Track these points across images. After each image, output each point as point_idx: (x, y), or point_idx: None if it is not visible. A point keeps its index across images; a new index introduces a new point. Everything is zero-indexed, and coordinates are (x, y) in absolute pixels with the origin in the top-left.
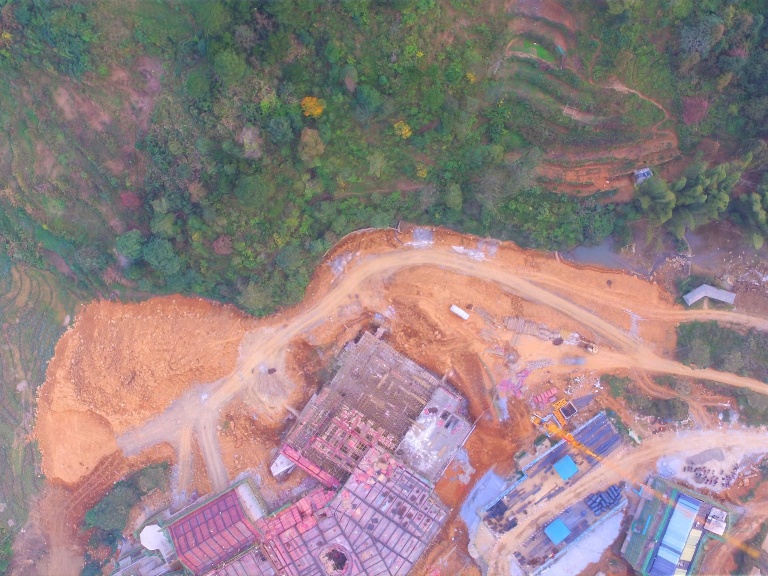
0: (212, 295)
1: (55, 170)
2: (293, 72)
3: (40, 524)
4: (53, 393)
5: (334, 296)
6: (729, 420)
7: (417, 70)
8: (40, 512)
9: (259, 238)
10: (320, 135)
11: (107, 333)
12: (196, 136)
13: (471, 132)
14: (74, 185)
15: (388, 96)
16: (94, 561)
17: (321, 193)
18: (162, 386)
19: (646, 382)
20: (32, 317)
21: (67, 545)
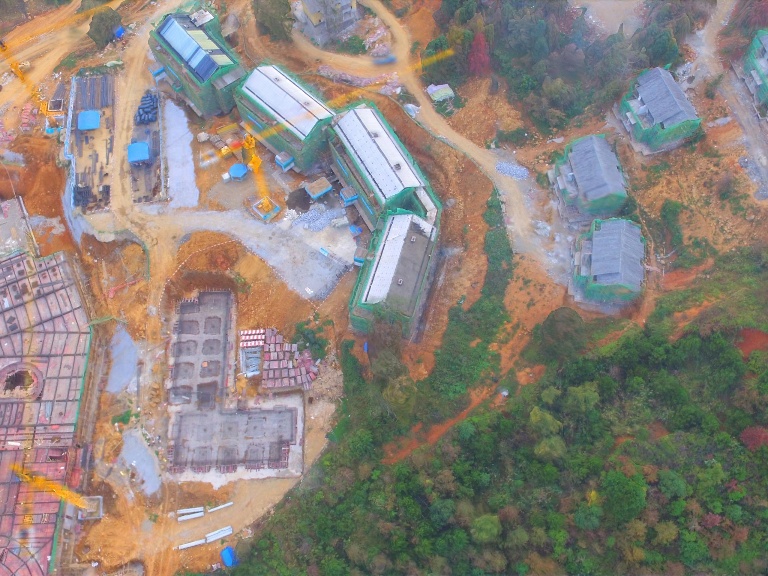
0: None
1: None
2: None
3: None
4: None
5: None
6: None
7: None
8: None
9: None
10: None
11: None
12: None
13: None
14: None
15: None
16: None
17: None
18: None
19: (86, 43)
20: None
21: None
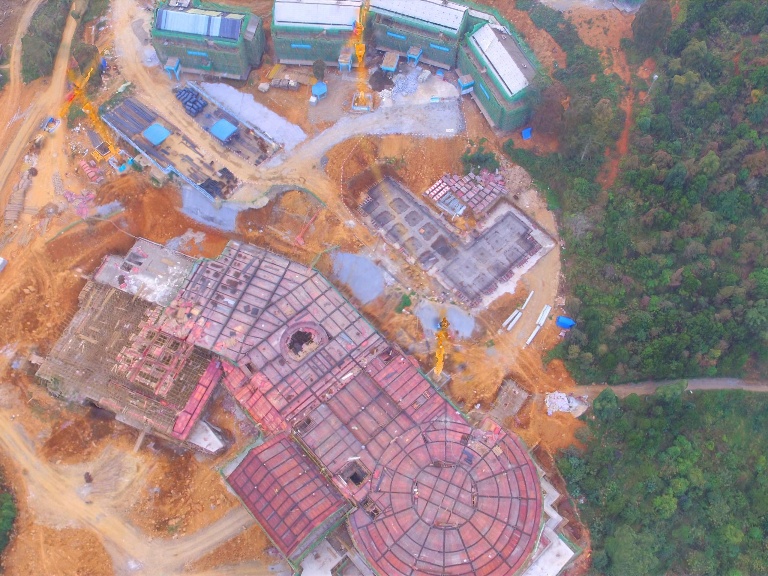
0: None
1: None
2: None
3: None
4: None
5: None
6: (104, 22)
7: None
8: None
9: None
10: None
11: None
12: None
13: None
14: None
15: None
16: None
17: None
18: None
19: None
20: None
21: None
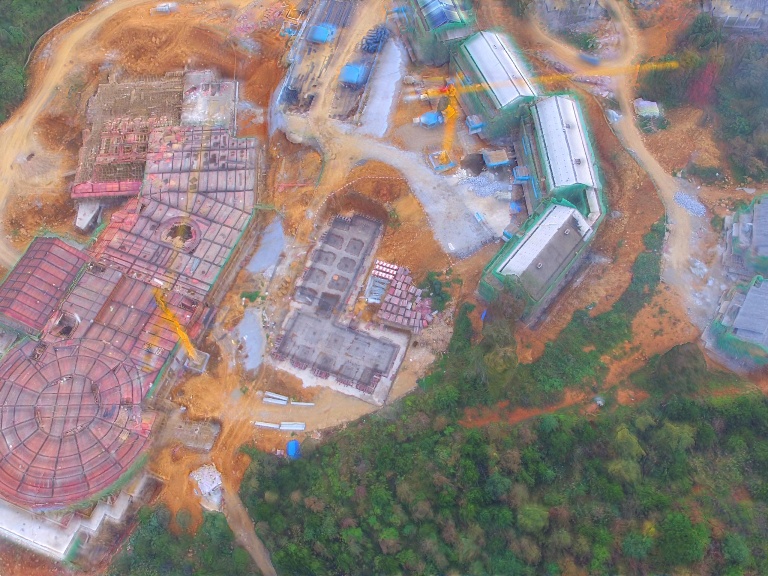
0: None
1: None
2: None
3: None
4: None
5: (52, 75)
6: None
7: None
8: None
9: None
10: None
11: None
12: None
13: None
14: None
15: None
16: None
17: None
18: None
19: None
20: None
21: None
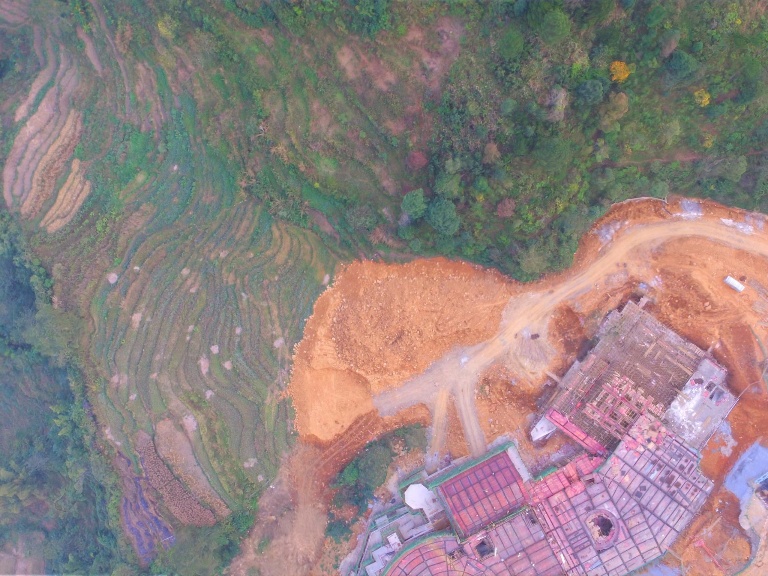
0: (477, 259)
1: (331, 129)
2: (613, 35)
3: (288, 481)
4: (314, 350)
5: (601, 264)
6: None
7: (742, 36)
8: (289, 469)
9: (540, 202)
10: (628, 99)
11: (374, 292)
12: (495, 97)
13: (762, 104)
14: (350, 144)
15: (701, 63)
16: (340, 520)
17: (603, 160)
18: (426, 347)
19: None
20: (292, 275)
21: (314, 503)
